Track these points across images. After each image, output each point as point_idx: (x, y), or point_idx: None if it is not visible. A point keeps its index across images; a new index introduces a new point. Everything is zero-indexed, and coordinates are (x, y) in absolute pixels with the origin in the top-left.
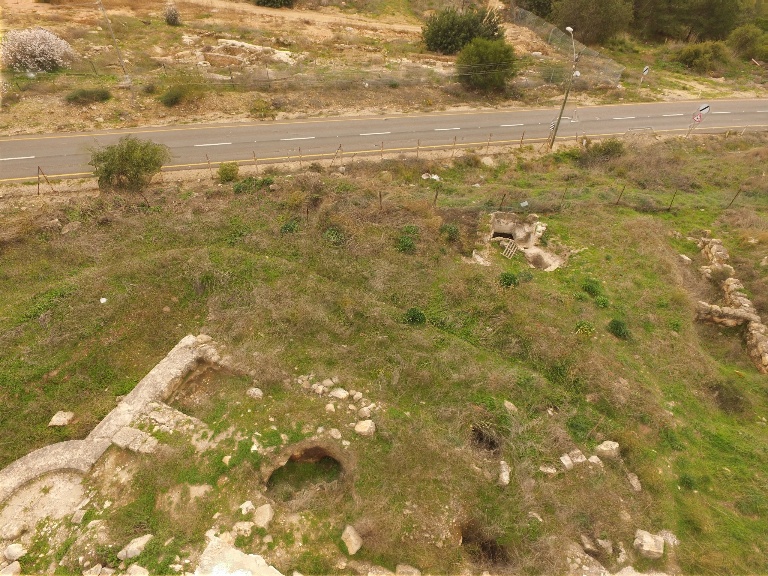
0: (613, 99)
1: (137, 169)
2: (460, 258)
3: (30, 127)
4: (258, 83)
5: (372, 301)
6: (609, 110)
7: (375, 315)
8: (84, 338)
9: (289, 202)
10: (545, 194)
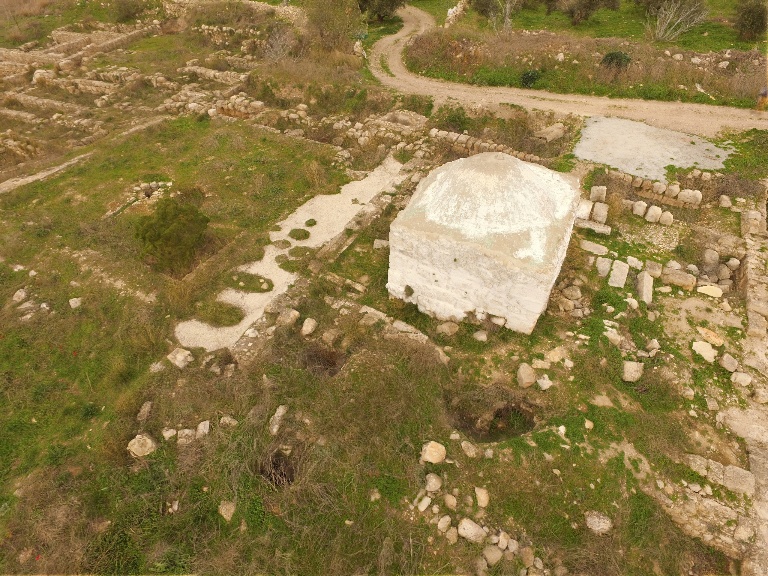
0: None
1: None
2: None
3: None
4: None
5: None
6: None
7: None
8: None
9: None
10: None
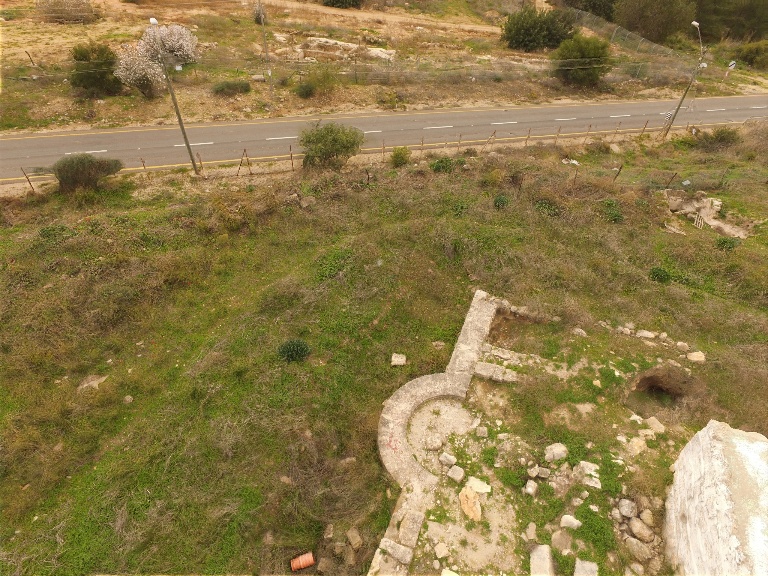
0: (697, 93)
1: (345, 150)
2: (659, 228)
3: (188, 117)
4: (378, 77)
5: (624, 261)
6: (699, 103)
7: (629, 273)
8: (384, 293)
9: (492, 179)
10: (695, 175)
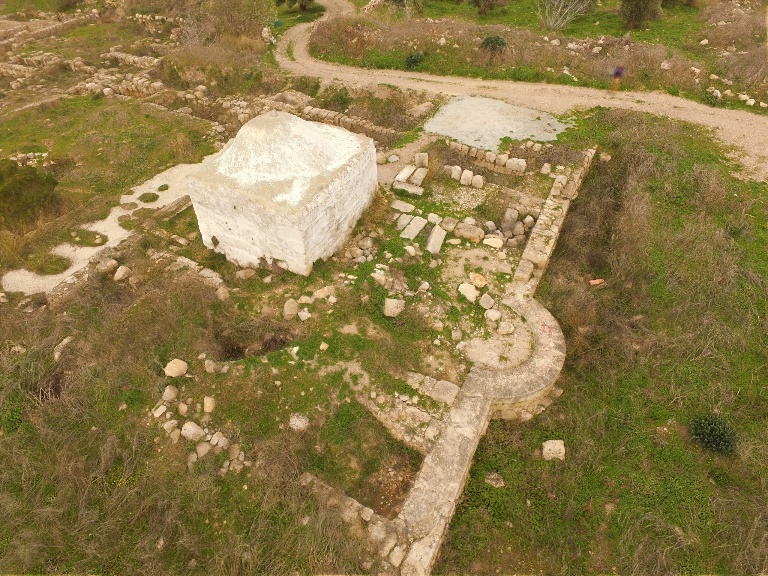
0: None
1: None
2: None
3: None
4: None
5: None
6: None
7: None
8: None
9: None
10: None
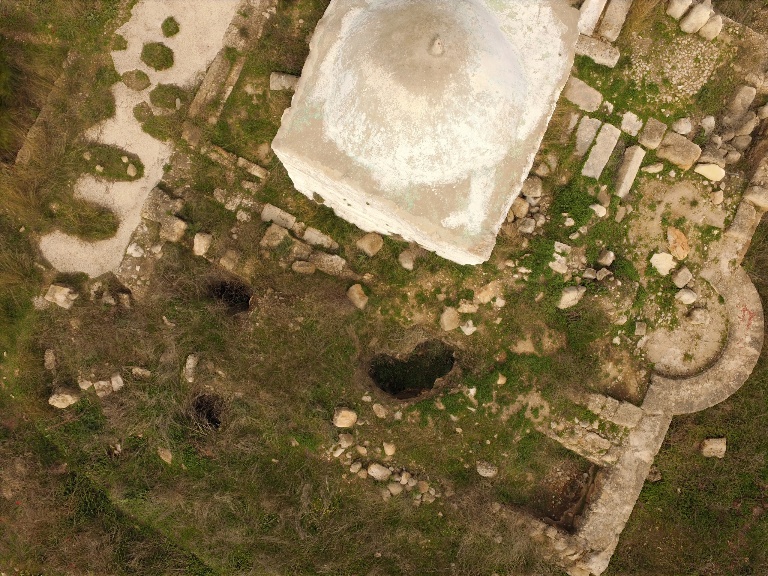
0: None
1: None
2: None
3: None
4: None
5: None
6: None
7: None
8: (746, 571)
9: None
10: None
